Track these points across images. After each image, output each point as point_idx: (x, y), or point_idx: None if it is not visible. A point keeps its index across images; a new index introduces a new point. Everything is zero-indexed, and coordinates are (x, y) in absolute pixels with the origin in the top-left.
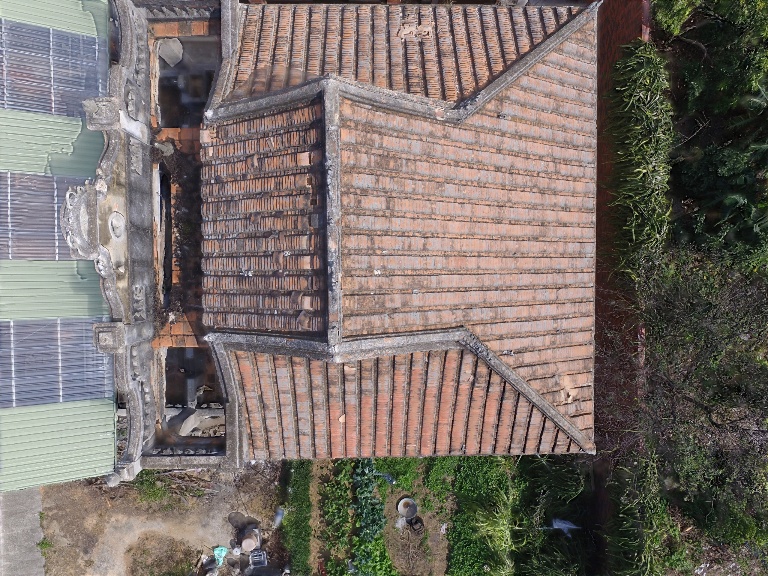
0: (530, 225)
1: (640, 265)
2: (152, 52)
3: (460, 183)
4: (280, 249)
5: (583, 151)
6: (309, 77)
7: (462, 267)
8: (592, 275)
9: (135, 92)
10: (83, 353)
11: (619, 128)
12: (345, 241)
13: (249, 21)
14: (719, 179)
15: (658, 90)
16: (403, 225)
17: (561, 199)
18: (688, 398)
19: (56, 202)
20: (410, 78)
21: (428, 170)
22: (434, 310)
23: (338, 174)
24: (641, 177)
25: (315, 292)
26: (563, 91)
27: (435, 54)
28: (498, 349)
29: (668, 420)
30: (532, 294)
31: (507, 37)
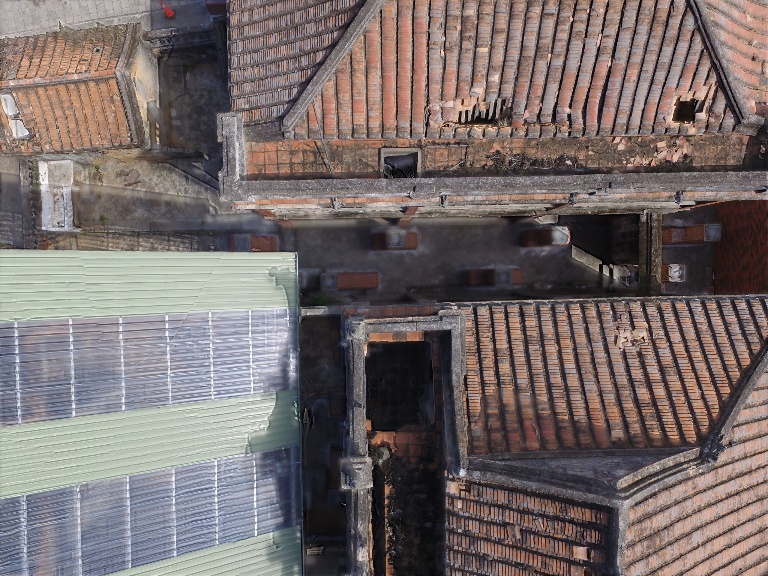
0: (752, 536)
1: None
2: None
3: (701, 524)
4: None
5: None
6: (540, 406)
7: None
8: None
9: None
10: None
11: None
12: None
13: None
14: None
15: None
16: None
17: None
18: None
19: (255, 479)
20: (641, 406)
21: (682, 529)
22: None
23: None
24: None
25: None
26: None
27: (657, 369)
28: None
29: None
30: None
31: (725, 344)
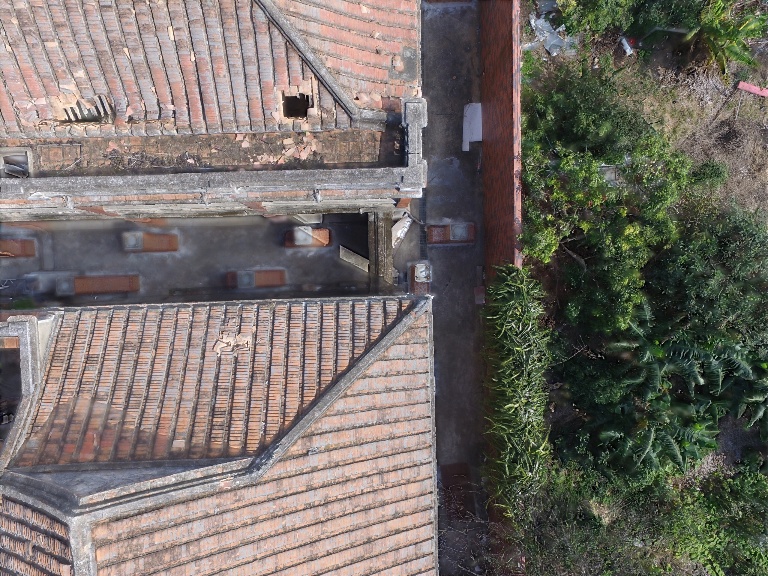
0: (352, 547)
1: (516, 497)
2: None
3: (261, 537)
4: None
5: (417, 451)
6: (111, 415)
7: None
8: (431, 573)
9: None
10: None
11: (494, 352)
12: None
13: (62, 334)
14: None
15: (530, 320)
16: None
17: (390, 508)
18: None
19: None
20: (215, 414)
21: (216, 544)
22: None
23: None
24: (514, 410)
25: None
26: (390, 398)
27: (249, 375)
28: None
29: None
30: None
31: (328, 348)
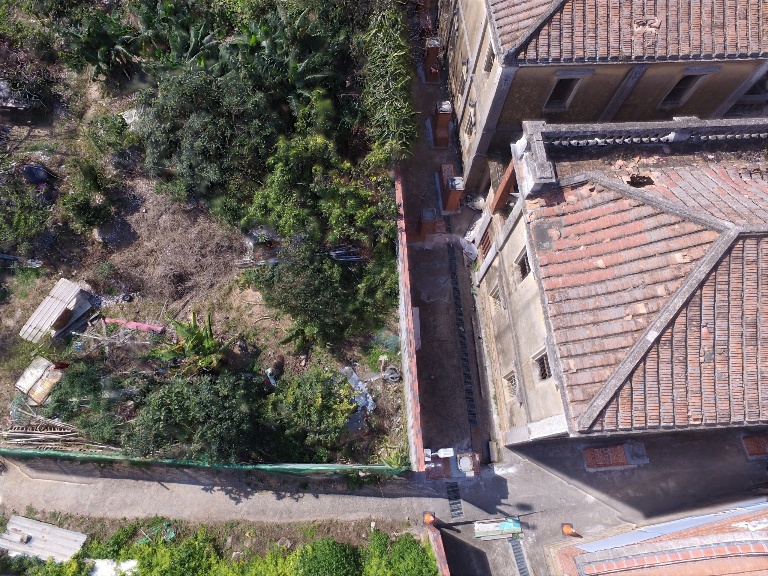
0: None
1: (390, 8)
2: None
3: None
4: None
5: None
6: None
7: None
8: None
9: None
10: None
11: None
12: None
13: None
14: None
15: None
16: None
17: None
18: None
19: None
20: None
21: None
22: None
23: None
24: None
25: None
26: None
27: (633, 2)
28: None
29: None
30: None
31: (579, 20)
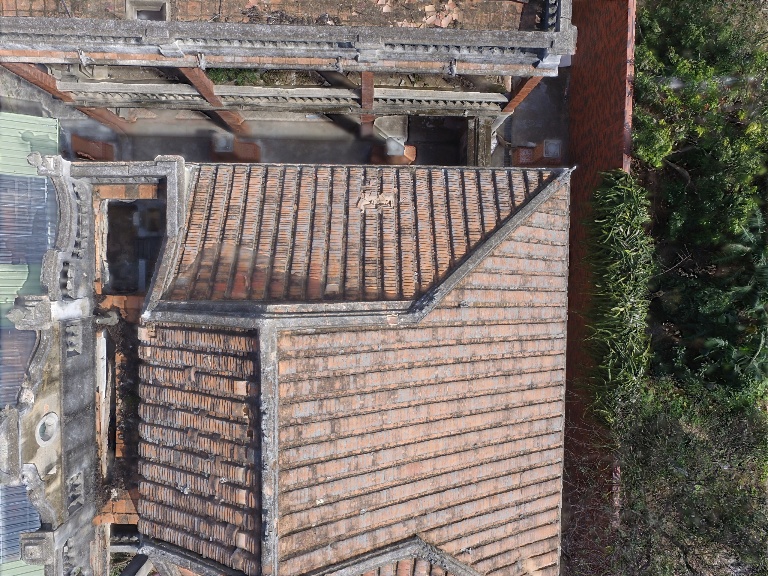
0: (492, 411)
1: (616, 404)
2: (98, 212)
3: (415, 384)
4: (216, 474)
5: (552, 323)
6: (259, 260)
7: (416, 473)
8: (559, 451)
9: (75, 269)
10: (26, 510)
11: (598, 259)
12: (283, 480)
13: (200, 186)
14: (700, 313)
15: (638, 224)
16: (350, 446)
17: (527, 378)
18: (664, 533)
19: None
20: (366, 263)
21: (379, 381)
22: (383, 526)
23: (275, 413)
24: (619, 314)
25: (250, 530)
26: (531, 265)
27: (395, 230)
28: (454, 550)
29: (644, 549)
30: (493, 484)
31: (473, 209)
